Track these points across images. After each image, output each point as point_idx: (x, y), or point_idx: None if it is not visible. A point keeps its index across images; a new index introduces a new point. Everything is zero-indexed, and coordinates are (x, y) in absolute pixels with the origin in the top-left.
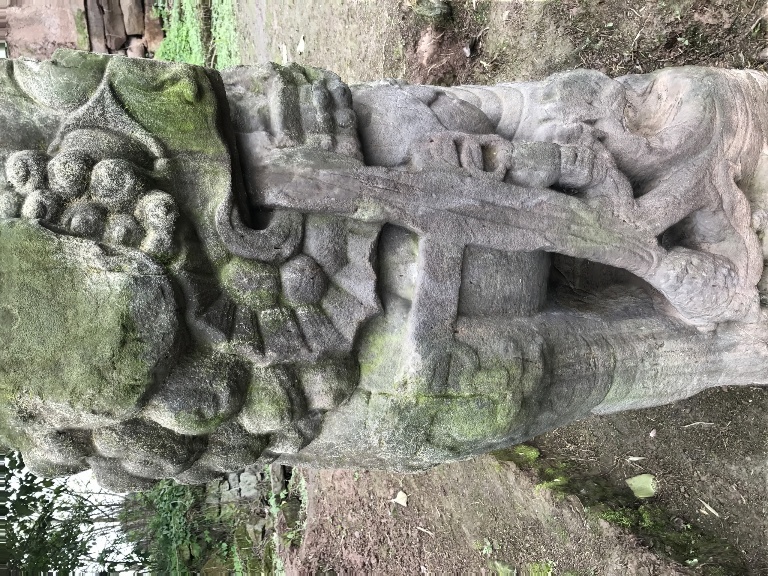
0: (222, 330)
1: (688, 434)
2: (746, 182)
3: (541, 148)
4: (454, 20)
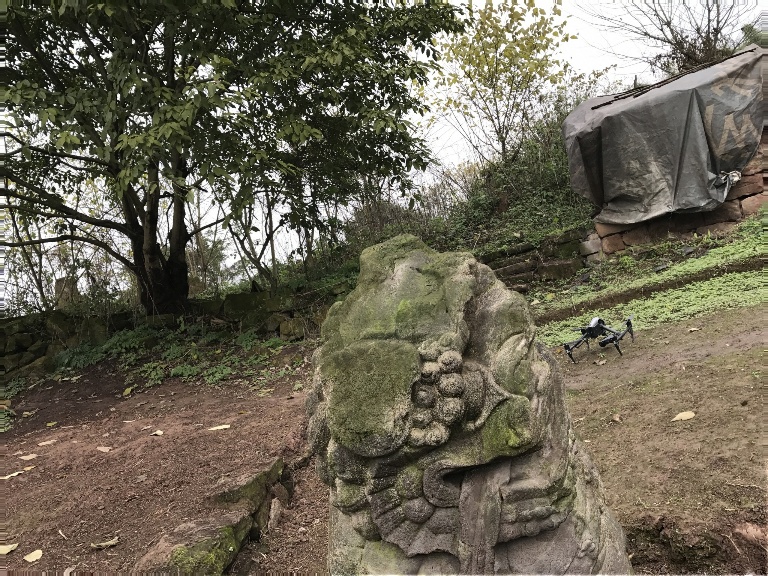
0: (376, 475)
1: None
2: None
3: None
4: None
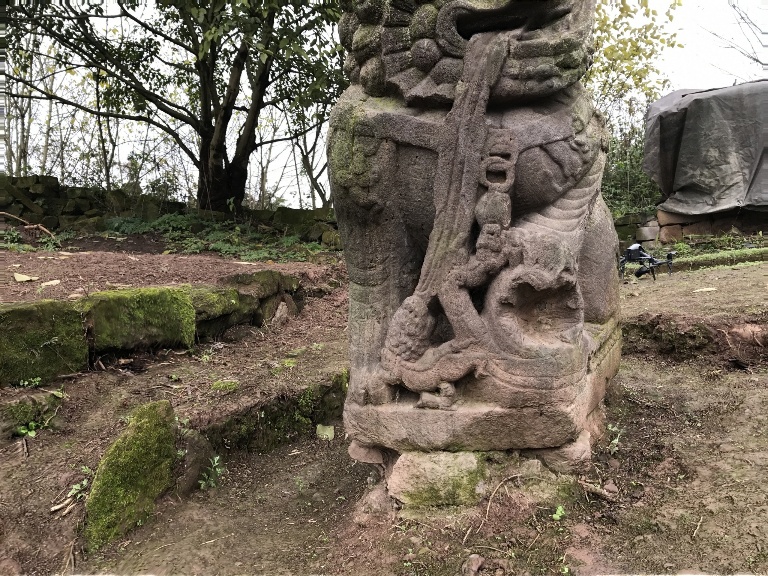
0: None
1: None
2: (479, 395)
3: (498, 209)
4: None
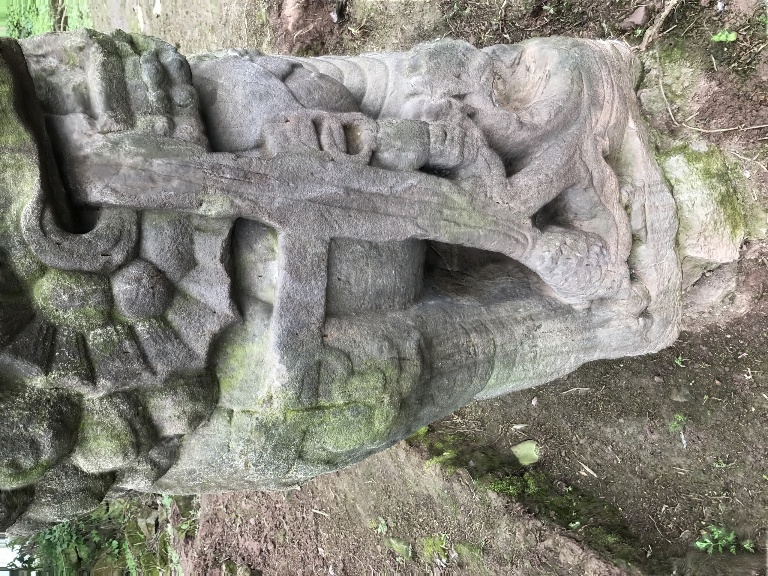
0: (36, 362)
1: (566, 400)
2: (614, 157)
3: (408, 127)
4: None
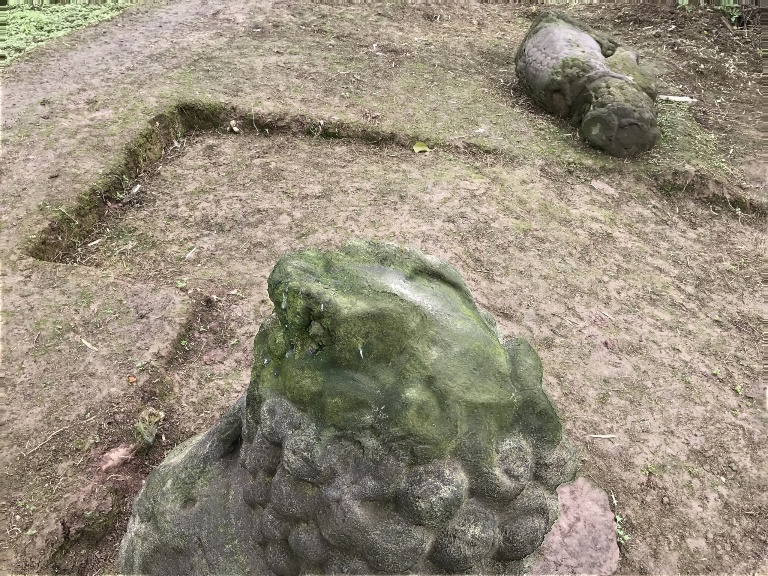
0: None
1: None
2: None
3: None
4: (148, 455)
